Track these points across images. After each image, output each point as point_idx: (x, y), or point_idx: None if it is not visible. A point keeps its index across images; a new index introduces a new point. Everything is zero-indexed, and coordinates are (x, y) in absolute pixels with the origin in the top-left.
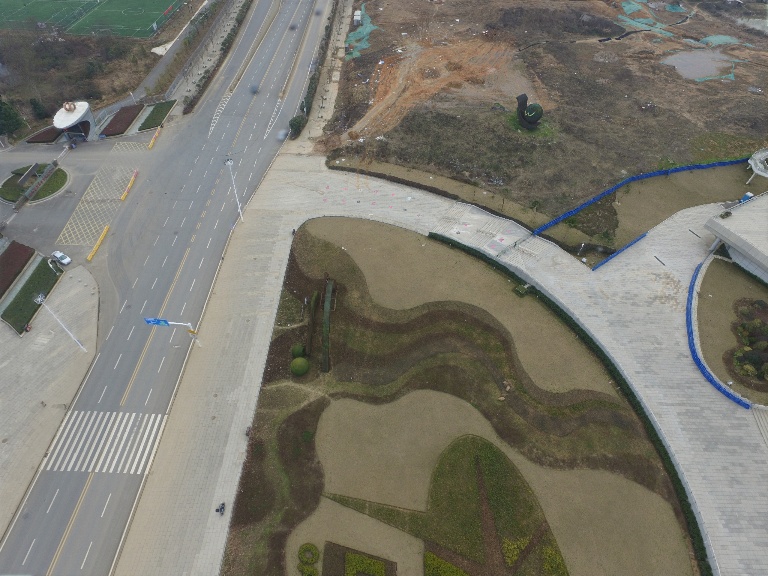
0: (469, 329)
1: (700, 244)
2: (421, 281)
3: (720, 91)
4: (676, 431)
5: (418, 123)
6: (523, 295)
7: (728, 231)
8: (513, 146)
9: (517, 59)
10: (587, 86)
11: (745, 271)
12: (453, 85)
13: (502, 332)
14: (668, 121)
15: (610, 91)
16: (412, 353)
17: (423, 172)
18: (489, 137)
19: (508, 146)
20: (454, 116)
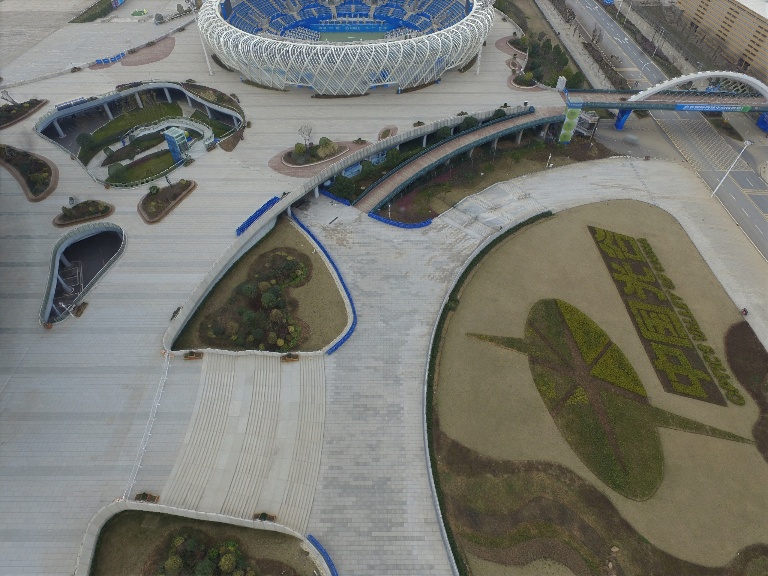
0: None
1: None
2: None
3: None
4: (414, 500)
5: None
6: None
7: None
8: None
9: None
10: None
11: None
12: None
13: None
14: None
15: None
16: None
17: None
18: None
19: None
20: None
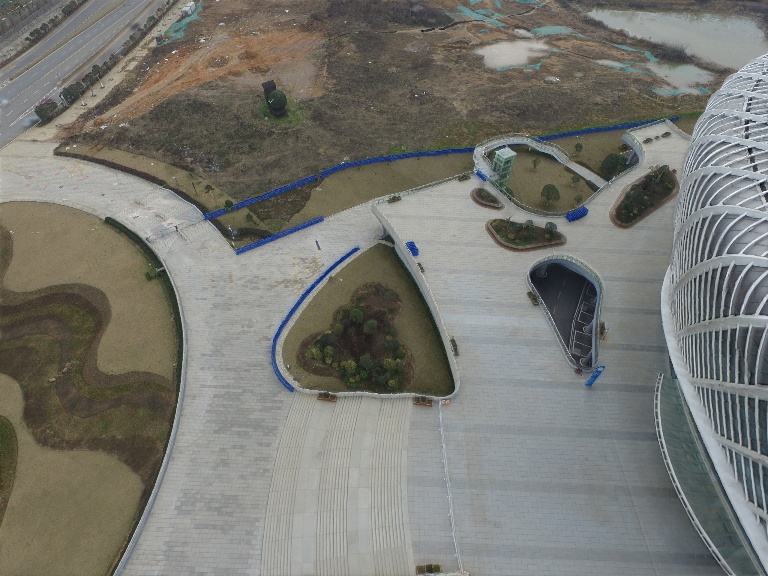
0: (74, 311)
1: (376, 229)
2: (63, 264)
3: (513, 80)
4: (199, 413)
5: (169, 110)
6: (151, 278)
7: (381, 215)
8: (250, 133)
9: (320, 48)
10: (370, 75)
11: (396, 256)
12: (232, 73)
13: (103, 314)
14: (432, 109)
15: (394, 80)
16: (0, 334)
17: (148, 158)
18: (231, 124)
19: (245, 133)
20: (210, 103)
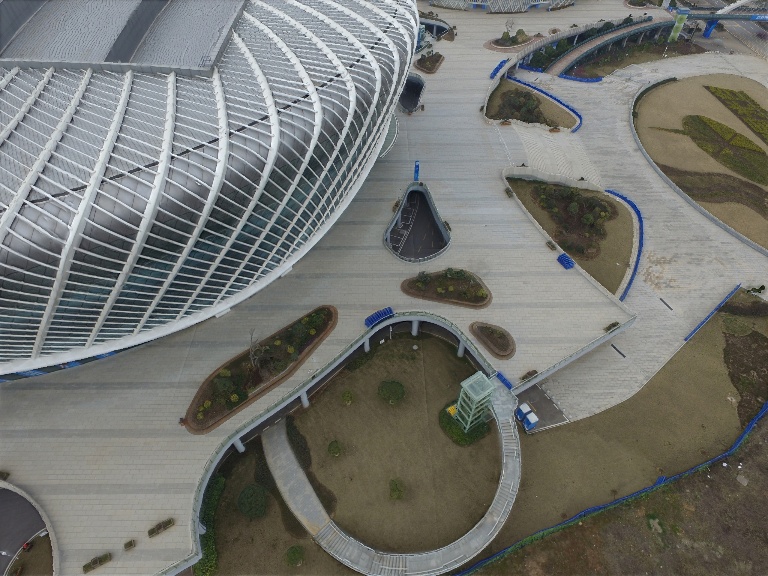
0: None
1: None
2: None
3: None
4: (654, 181)
5: None
6: None
7: None
8: None
9: None
10: None
11: None
12: None
13: None
14: None
15: None
16: None
17: None
18: None
19: None
20: None
